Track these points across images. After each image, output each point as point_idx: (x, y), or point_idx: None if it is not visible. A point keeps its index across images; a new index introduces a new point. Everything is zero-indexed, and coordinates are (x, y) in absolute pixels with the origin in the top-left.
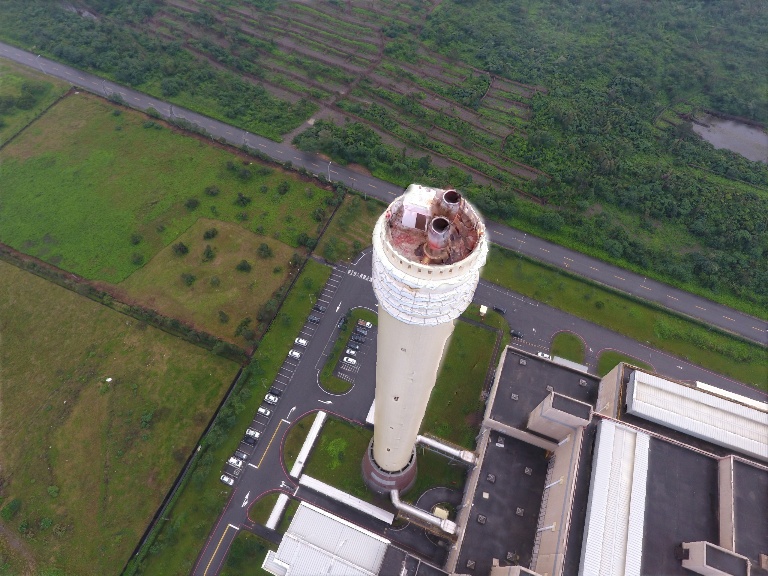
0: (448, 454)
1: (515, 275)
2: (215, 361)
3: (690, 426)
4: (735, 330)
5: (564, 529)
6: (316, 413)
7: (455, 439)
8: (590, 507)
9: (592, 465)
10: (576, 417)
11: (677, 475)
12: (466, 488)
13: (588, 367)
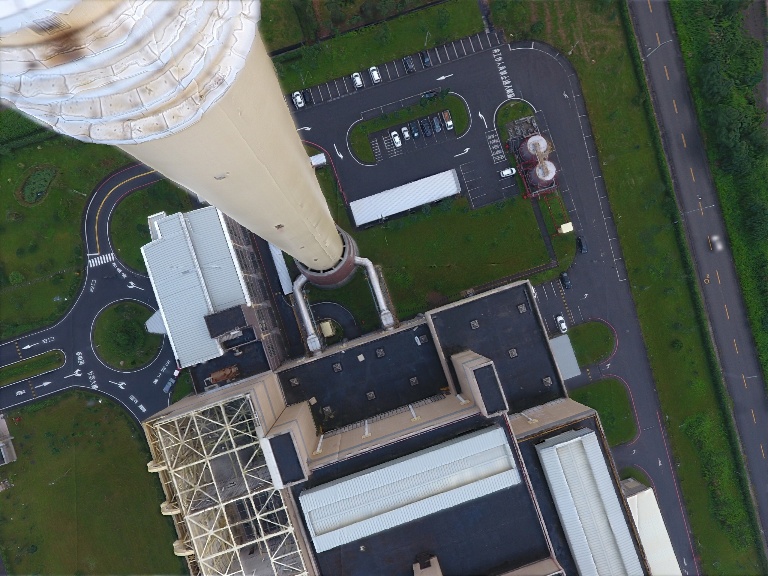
0: (377, 300)
1: (643, 232)
2: (286, 11)
3: (568, 516)
4: (759, 499)
5: (362, 448)
6: (321, 153)
7: (403, 296)
8: (397, 462)
9: (445, 442)
10: (482, 400)
11: (502, 524)
12: (364, 335)
13: (585, 373)
